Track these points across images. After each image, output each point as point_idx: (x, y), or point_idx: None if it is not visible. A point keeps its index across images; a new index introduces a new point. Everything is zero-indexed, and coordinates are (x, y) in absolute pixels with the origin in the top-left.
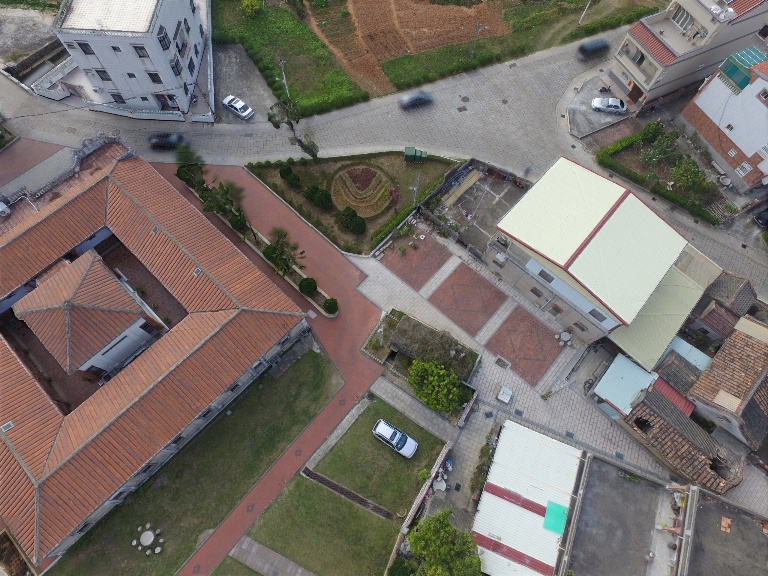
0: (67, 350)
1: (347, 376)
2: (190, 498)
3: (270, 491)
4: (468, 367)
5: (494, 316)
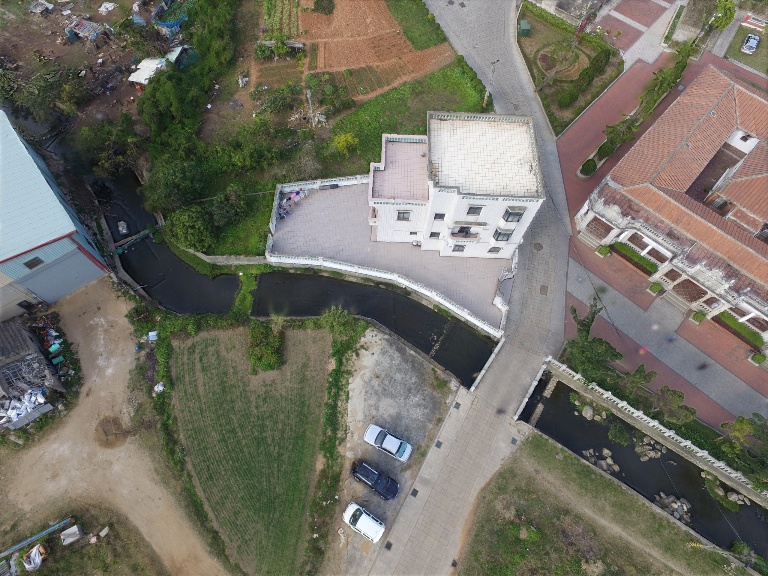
0: None
1: None
2: None
3: None
4: None
5: None
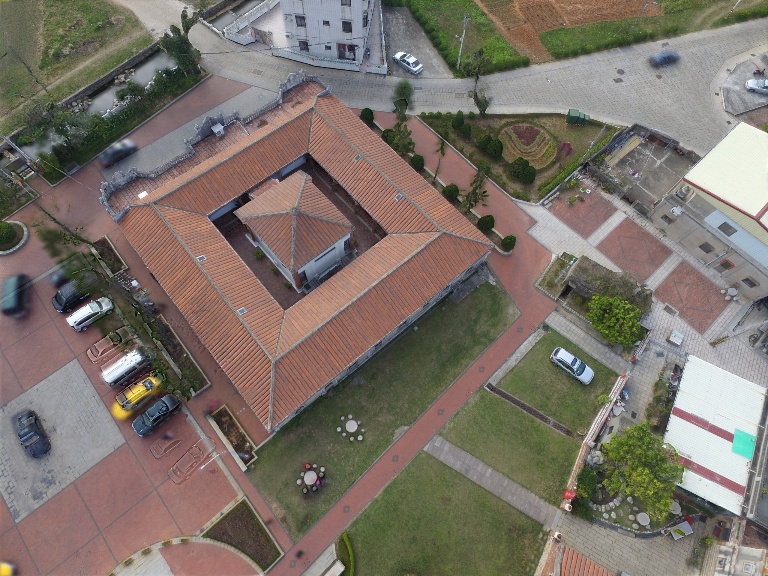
0: (292, 251)
1: (523, 308)
2: (385, 398)
3: (458, 399)
4: (650, 305)
5: (660, 268)
